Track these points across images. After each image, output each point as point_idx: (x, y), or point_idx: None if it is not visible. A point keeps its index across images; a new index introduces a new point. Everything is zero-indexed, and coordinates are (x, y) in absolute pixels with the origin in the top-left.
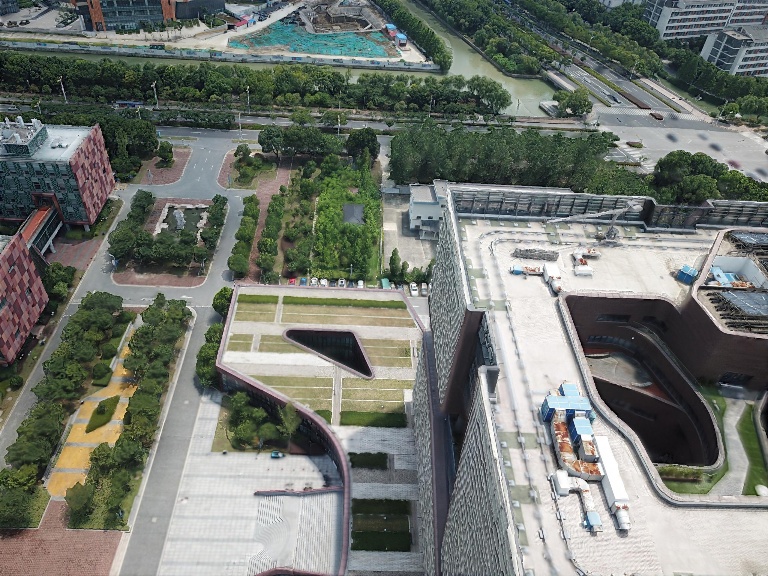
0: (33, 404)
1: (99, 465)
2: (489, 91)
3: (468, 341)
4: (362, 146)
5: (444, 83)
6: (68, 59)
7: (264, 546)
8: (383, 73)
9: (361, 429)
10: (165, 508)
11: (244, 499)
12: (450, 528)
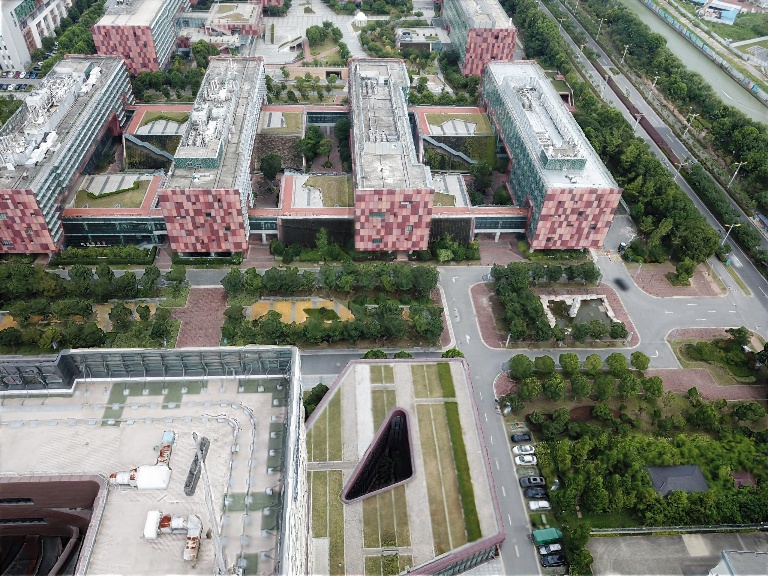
0: None
1: (262, 317)
2: None
3: None
4: None
5: None
6: None
7: None
8: None
9: None
10: None
11: None
12: None
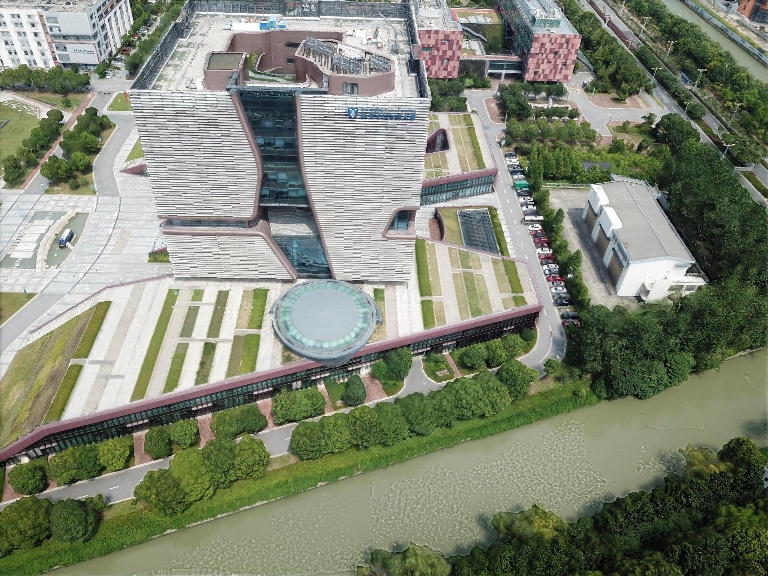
0: None
1: None
2: None
3: None
4: None
5: None
6: None
7: None
8: None
9: None
10: None
11: None
12: None
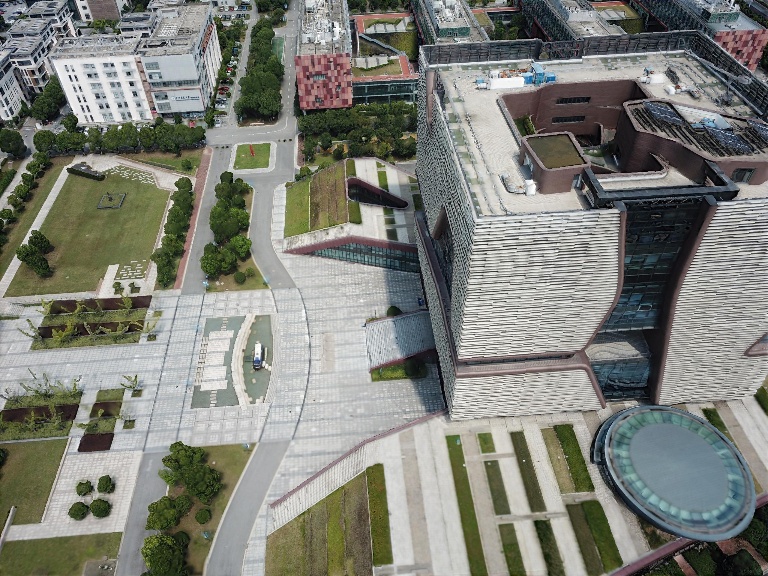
0: None
1: None
2: None
3: None
4: None
5: None
6: None
7: None
8: None
9: None
10: None
11: None
12: None
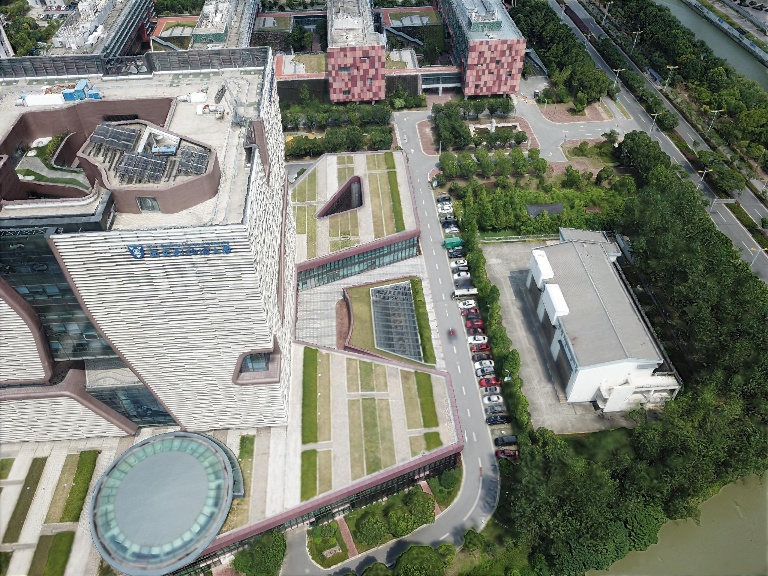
0: None
1: None
2: None
3: None
4: None
5: None
6: (683, 29)
7: None
8: None
9: None
10: None
11: None
12: None
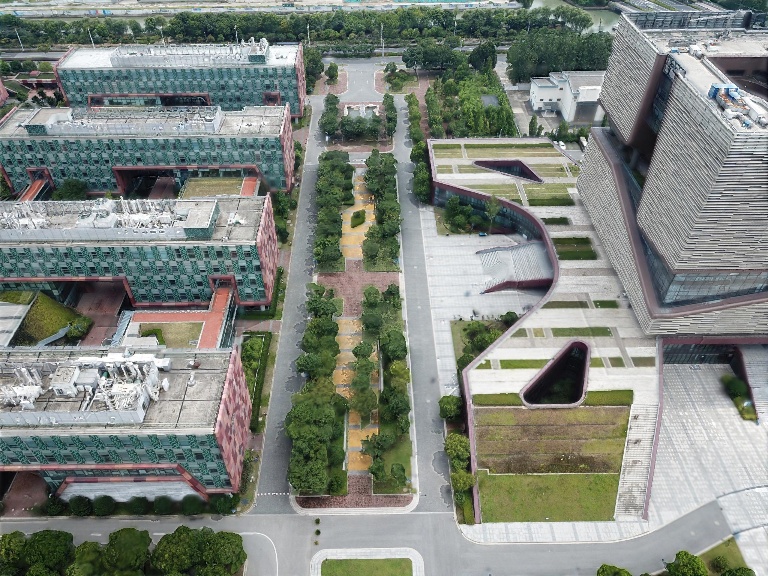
0: (308, 216)
1: (375, 236)
2: (574, 15)
3: (655, 79)
4: (485, 57)
5: (534, 13)
6: (231, 15)
7: (492, 276)
8: (483, 9)
9: (544, 207)
10: (420, 262)
11: (470, 256)
12: (649, 188)
